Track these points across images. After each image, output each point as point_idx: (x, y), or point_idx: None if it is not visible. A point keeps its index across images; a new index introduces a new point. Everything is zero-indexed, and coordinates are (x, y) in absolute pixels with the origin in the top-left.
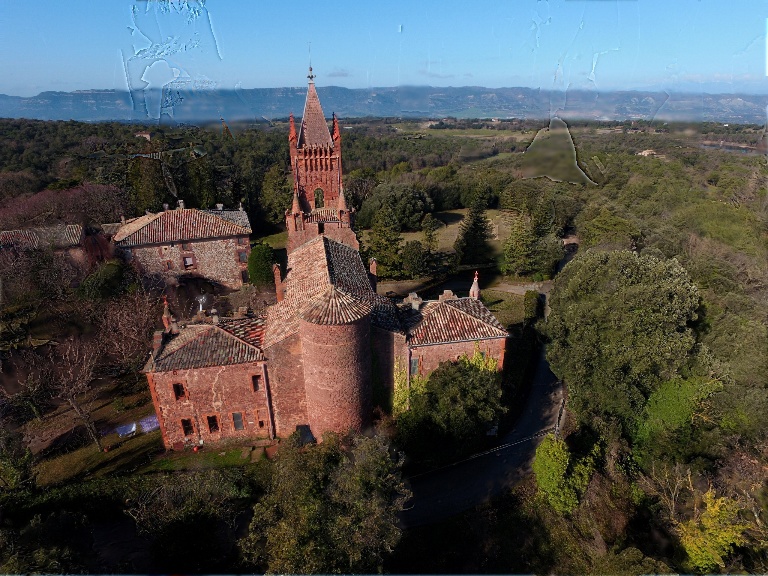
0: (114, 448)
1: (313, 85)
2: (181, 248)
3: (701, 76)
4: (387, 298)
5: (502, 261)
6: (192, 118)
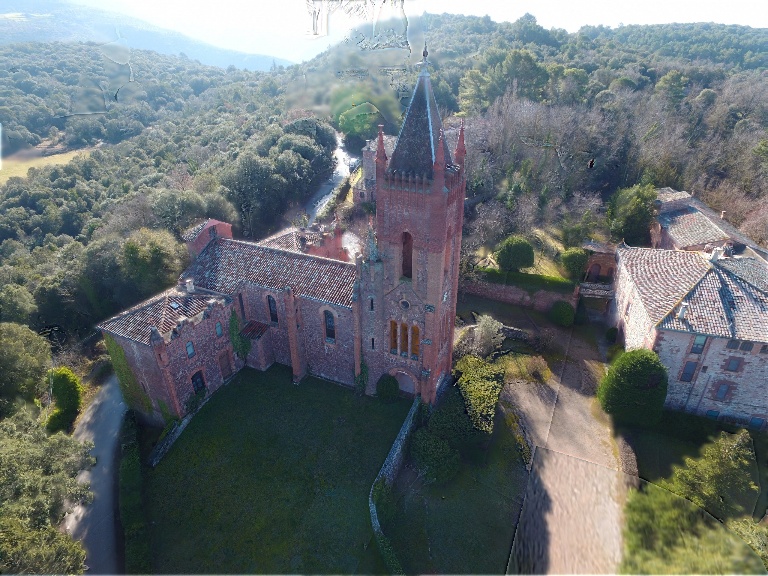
0: None
1: (420, 78)
2: (632, 289)
3: None
4: (231, 290)
5: None
6: (393, 103)
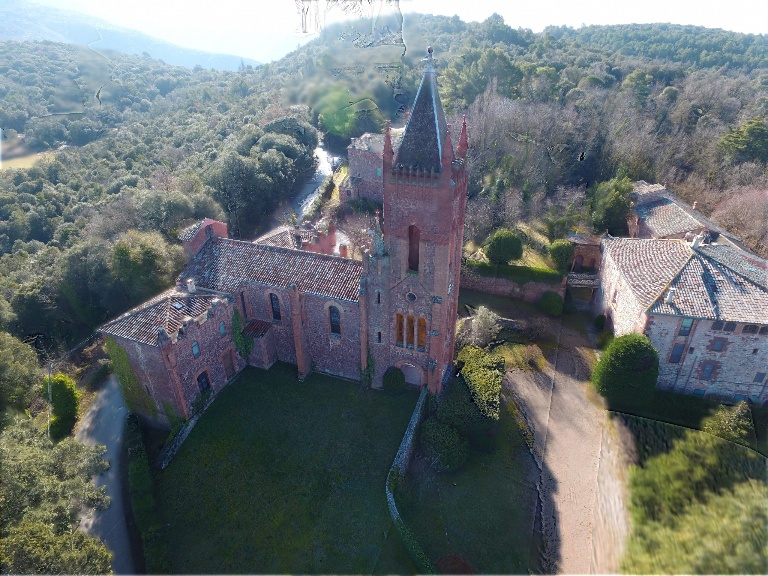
0: None
1: (425, 74)
2: (619, 277)
3: None
4: (233, 289)
5: None
6: (388, 100)
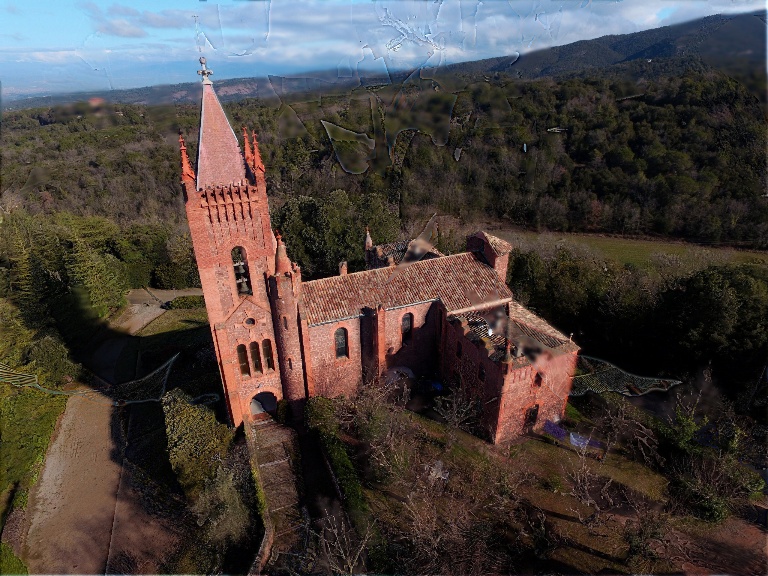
0: (592, 454)
1: None
2: None
3: (104, 69)
4: None
5: (91, 308)
6: None
